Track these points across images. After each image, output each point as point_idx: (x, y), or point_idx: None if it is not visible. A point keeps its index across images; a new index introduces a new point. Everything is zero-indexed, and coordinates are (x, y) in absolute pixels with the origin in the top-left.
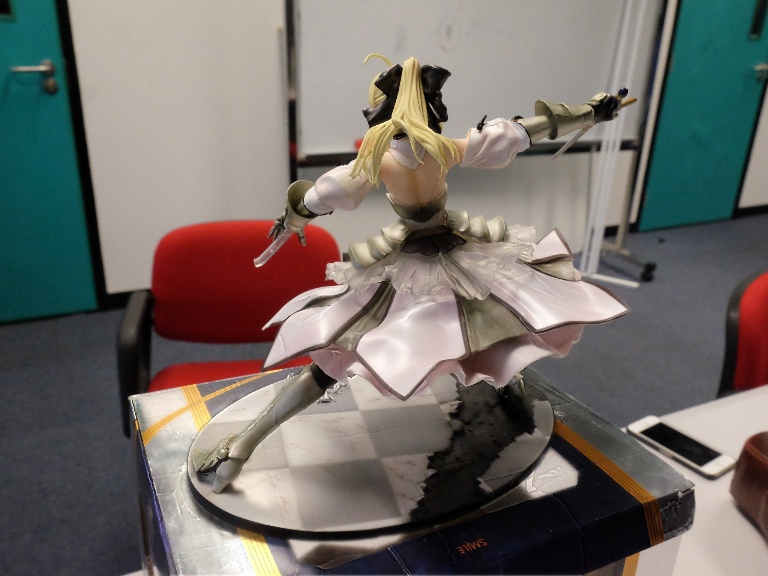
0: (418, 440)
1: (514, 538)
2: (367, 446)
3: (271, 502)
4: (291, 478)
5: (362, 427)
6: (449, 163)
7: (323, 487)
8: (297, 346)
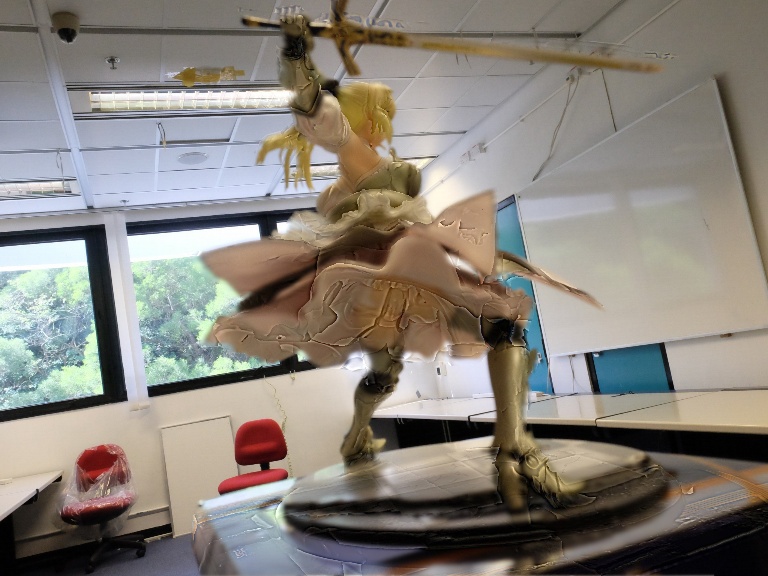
0: (427, 503)
1: (238, 567)
2: (412, 490)
3: (326, 483)
4: (357, 481)
5: (449, 482)
6: (337, 150)
7: (342, 490)
8: (320, 338)
